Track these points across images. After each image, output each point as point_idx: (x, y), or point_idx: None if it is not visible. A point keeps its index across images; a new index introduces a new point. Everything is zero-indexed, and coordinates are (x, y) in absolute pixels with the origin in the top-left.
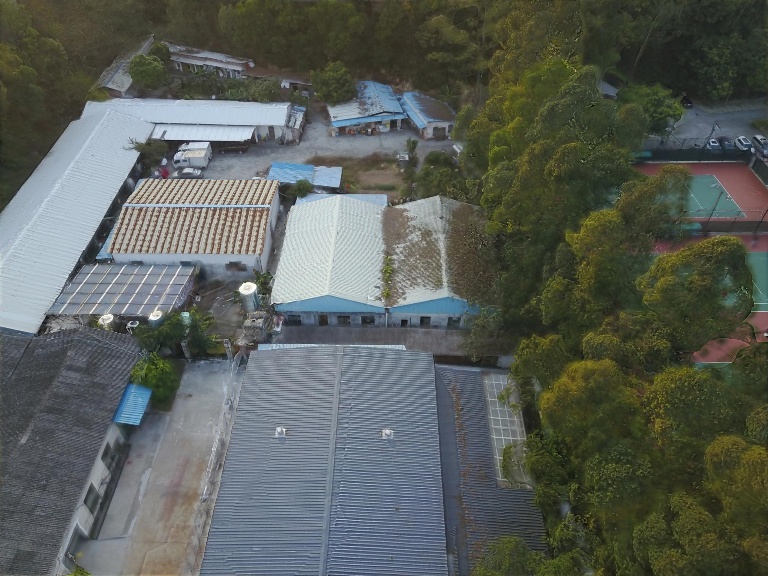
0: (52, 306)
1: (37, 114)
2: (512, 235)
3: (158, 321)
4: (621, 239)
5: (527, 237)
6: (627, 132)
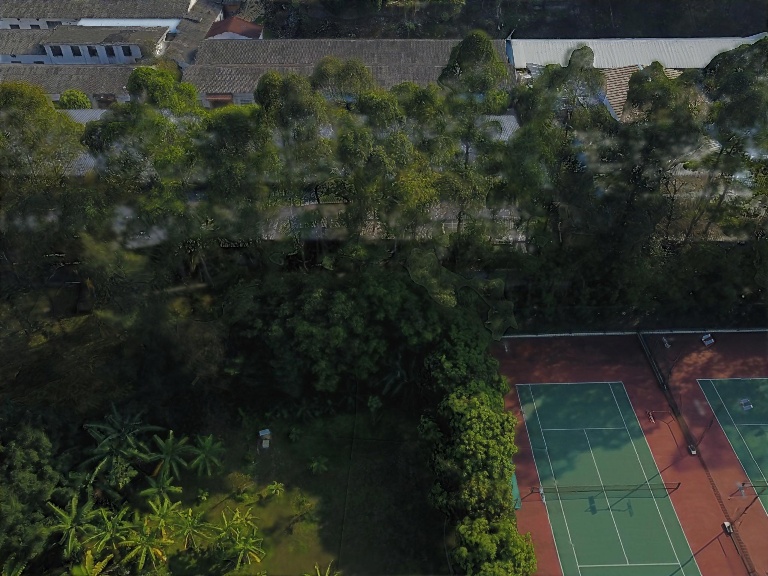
0: (534, 64)
1: (719, 15)
2: (690, 207)
3: (530, 89)
4: (543, 84)
5: (726, 249)
6: (732, 109)
